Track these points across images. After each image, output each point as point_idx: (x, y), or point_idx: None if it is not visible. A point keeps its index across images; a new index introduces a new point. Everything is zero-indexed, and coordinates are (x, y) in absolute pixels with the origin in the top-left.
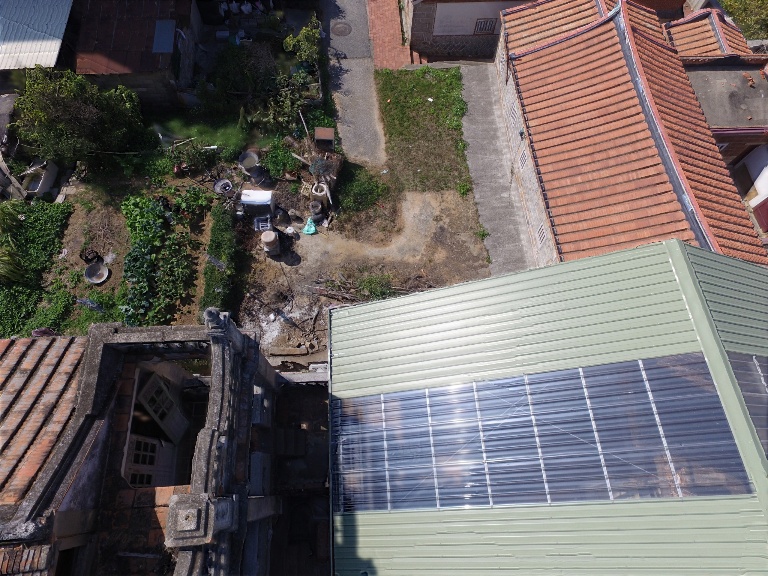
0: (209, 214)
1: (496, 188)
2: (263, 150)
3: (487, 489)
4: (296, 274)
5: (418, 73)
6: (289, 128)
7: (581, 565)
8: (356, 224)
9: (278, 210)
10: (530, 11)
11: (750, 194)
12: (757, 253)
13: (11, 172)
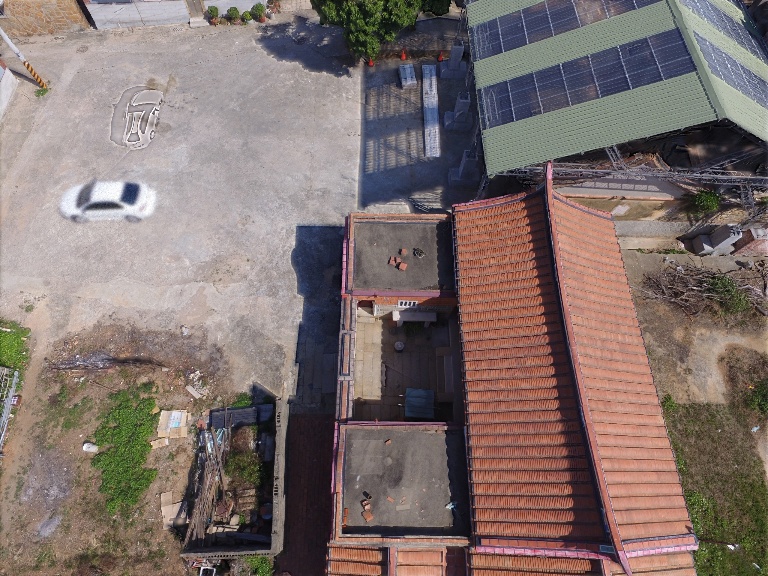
0: None
1: None
2: None
3: None
4: None
5: None
6: None
7: None
8: (766, 364)
9: None
10: None
11: None
12: (470, 261)
13: None
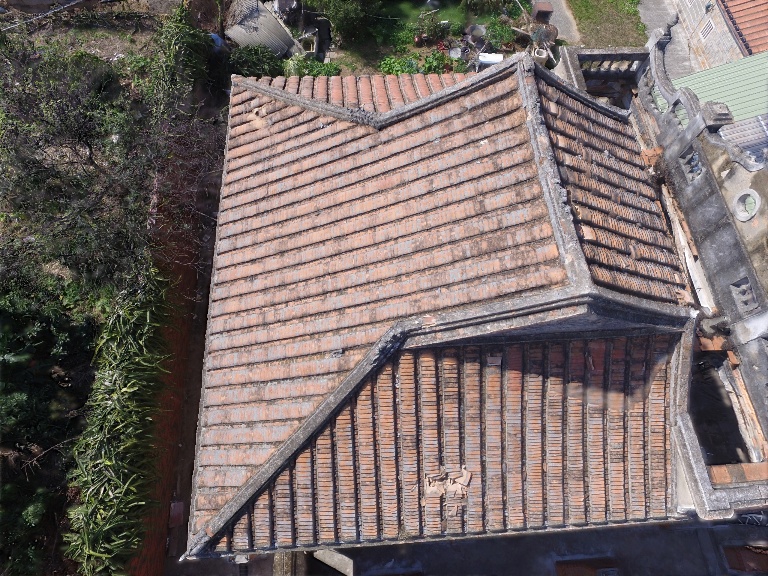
0: (452, 72)
1: (678, 58)
2: None
3: None
4: None
5: None
6: (502, 8)
7: None
8: None
9: None
10: None
11: None
12: None
13: (293, 36)
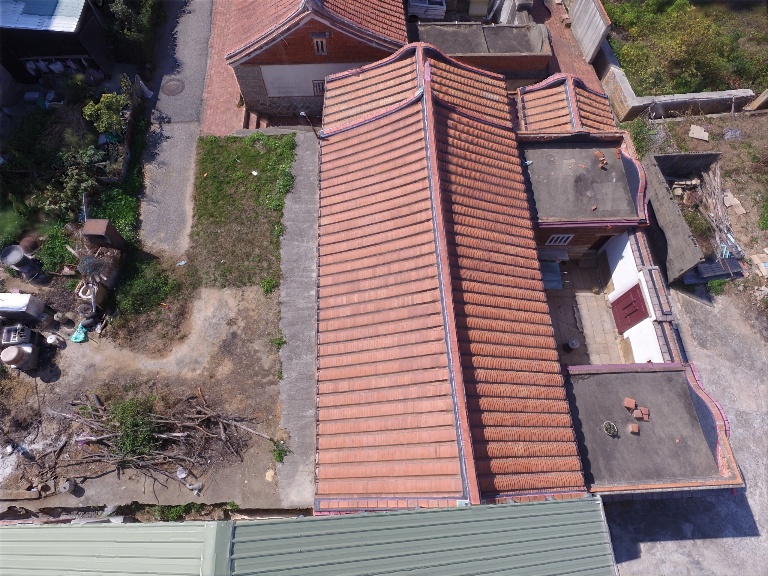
0: None
1: (306, 284)
2: (40, 239)
3: None
4: (51, 393)
5: (246, 141)
6: None
7: None
8: (131, 331)
9: (42, 314)
10: (353, 79)
11: (609, 287)
12: (551, 398)
13: None
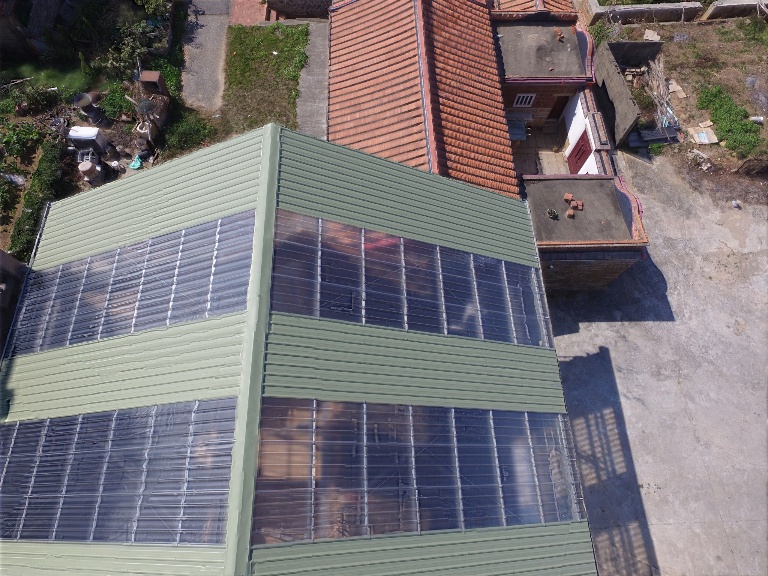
0: (40, 147)
1: (317, 132)
2: (103, 93)
3: (99, 328)
4: None
5: (268, 29)
6: None
7: (134, 376)
8: None
9: (107, 146)
10: None
11: (566, 145)
12: (505, 182)
13: None
